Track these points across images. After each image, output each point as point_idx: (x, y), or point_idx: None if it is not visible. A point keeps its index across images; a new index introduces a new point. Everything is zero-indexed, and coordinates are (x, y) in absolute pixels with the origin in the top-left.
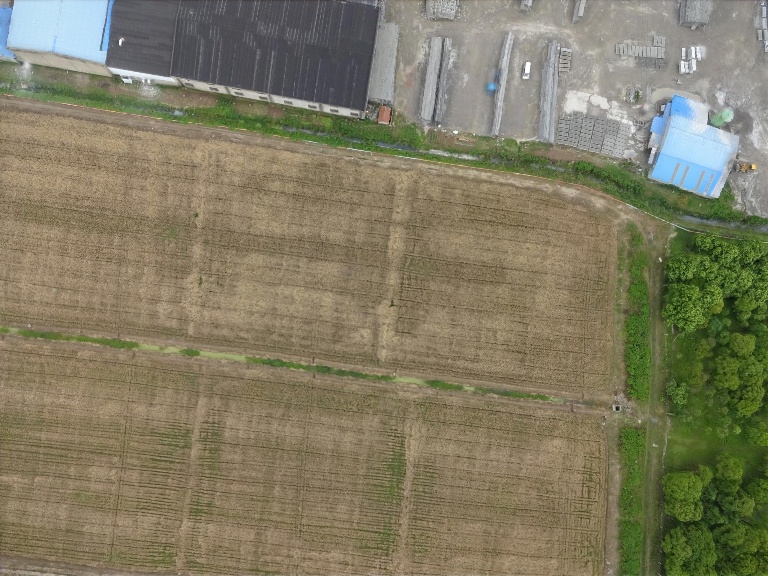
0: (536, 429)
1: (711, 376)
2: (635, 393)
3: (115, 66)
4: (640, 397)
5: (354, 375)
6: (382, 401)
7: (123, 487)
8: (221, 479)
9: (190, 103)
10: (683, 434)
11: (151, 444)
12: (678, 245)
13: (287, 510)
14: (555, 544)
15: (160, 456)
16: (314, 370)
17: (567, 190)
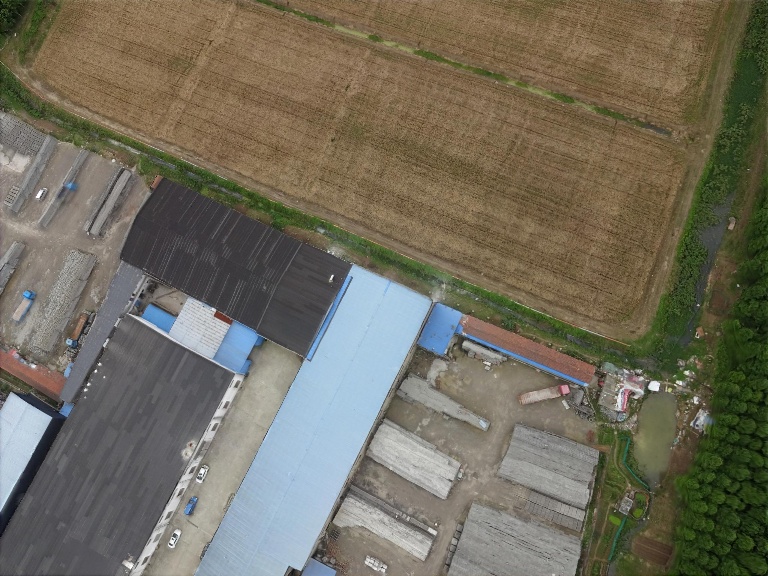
0: None
1: None
2: None
3: (346, 263)
4: None
5: None
6: None
7: None
8: None
9: (306, 233)
10: None
11: None
12: None
13: None
14: None
15: None
16: (287, 9)
17: (54, 98)
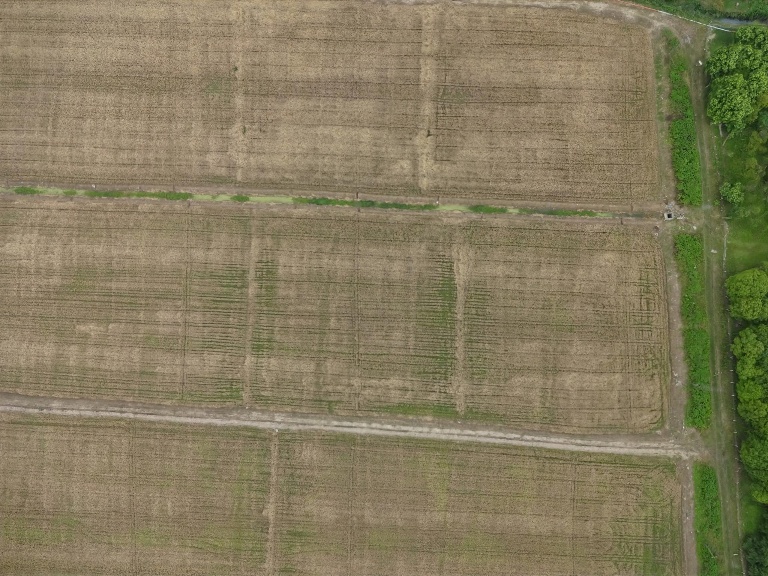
0: (586, 244)
1: (767, 172)
2: (687, 198)
3: None
4: (692, 201)
5: (398, 207)
6: (427, 228)
7: (189, 328)
8: (279, 315)
9: None
10: (743, 238)
11: (211, 286)
12: (718, 46)
13: (344, 340)
14: (617, 358)
15: (220, 297)
16: (359, 205)
17: (595, 5)
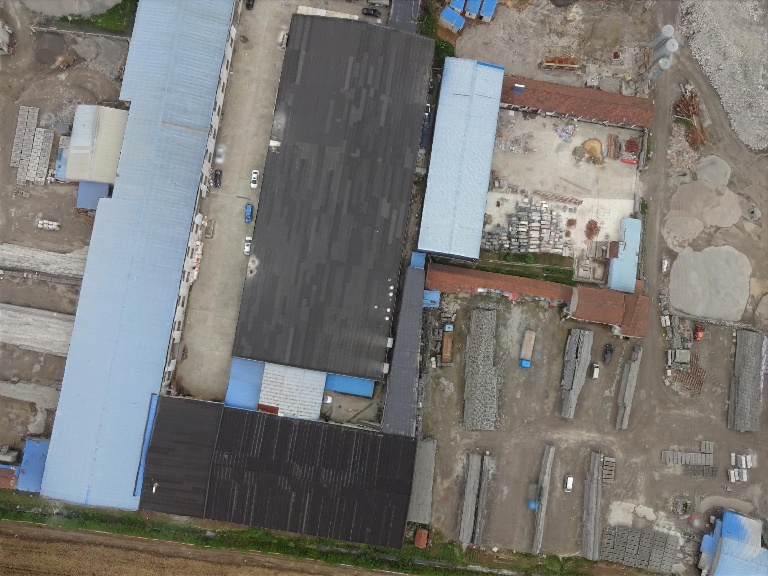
0: None
1: None
2: None
3: (148, 509)
4: None
5: None
6: None
7: None
8: None
9: (222, 526)
10: None
11: None
12: None
13: None
14: None
15: None
16: None
17: None
